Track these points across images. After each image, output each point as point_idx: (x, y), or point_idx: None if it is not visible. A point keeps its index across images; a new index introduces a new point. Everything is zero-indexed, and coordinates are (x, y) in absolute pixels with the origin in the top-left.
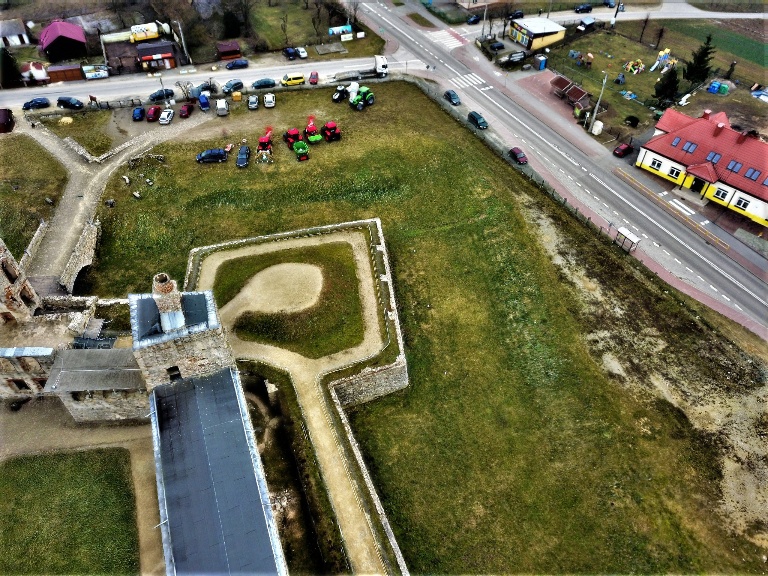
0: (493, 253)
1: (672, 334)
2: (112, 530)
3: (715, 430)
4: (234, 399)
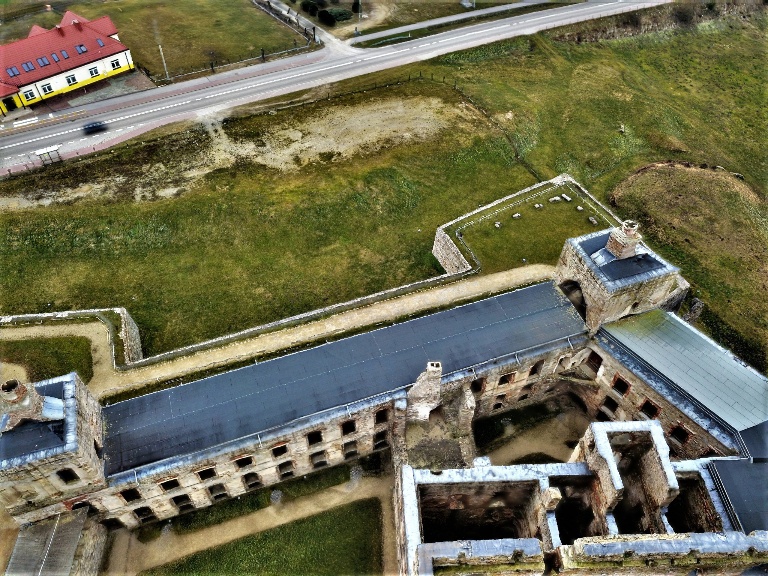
0: (7, 247)
1: (152, 158)
2: (229, 567)
3: (234, 159)
4: (144, 398)
